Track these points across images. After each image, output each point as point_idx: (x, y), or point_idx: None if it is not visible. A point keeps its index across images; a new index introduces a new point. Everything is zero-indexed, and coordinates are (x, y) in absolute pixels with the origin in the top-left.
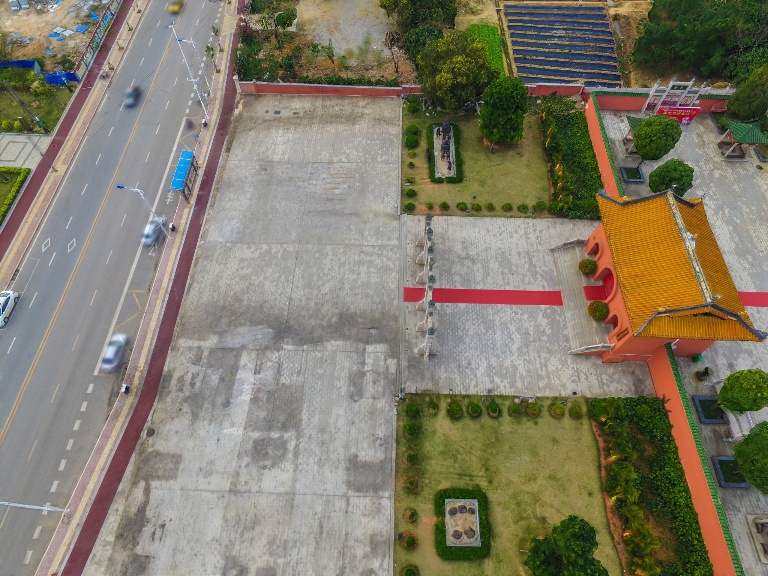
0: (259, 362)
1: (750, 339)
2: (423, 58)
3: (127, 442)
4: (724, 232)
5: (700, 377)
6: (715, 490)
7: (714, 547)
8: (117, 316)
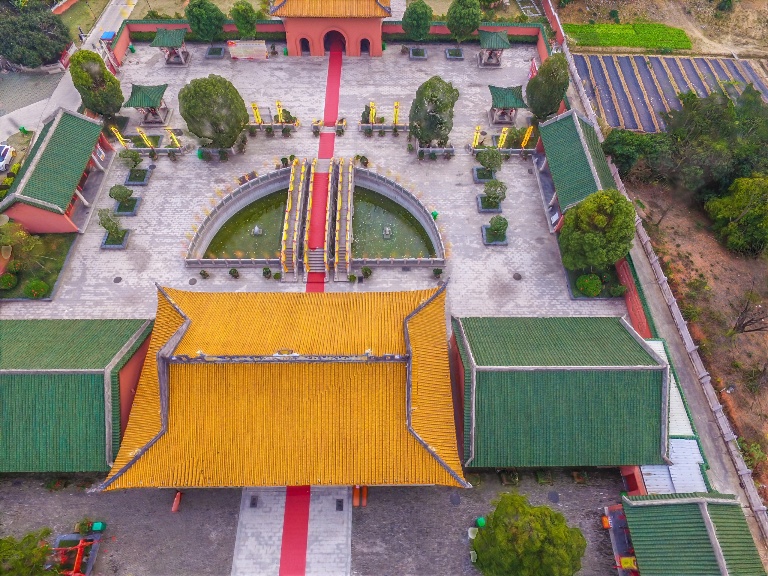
0: None
1: None
2: None
3: None
4: (398, 92)
5: None
6: None
7: None
8: None
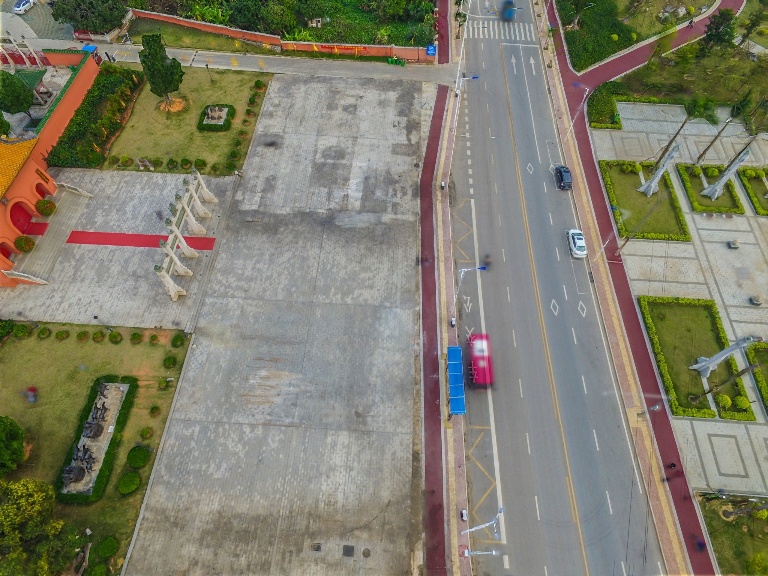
0: (345, 202)
1: None
2: (35, 573)
3: (431, 161)
4: None
5: None
6: None
7: None
8: (475, 240)
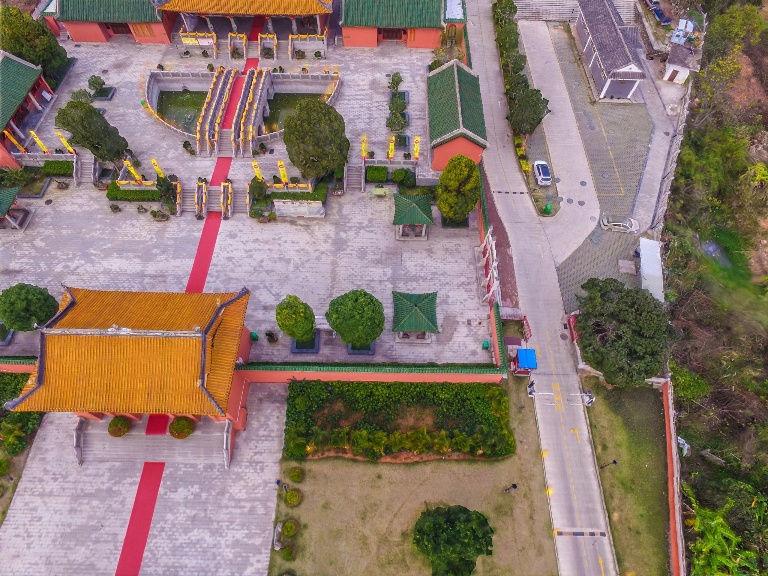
0: None
1: (246, 301)
2: None
3: None
4: (118, 263)
5: (274, 340)
6: (380, 369)
7: (422, 378)
8: None
